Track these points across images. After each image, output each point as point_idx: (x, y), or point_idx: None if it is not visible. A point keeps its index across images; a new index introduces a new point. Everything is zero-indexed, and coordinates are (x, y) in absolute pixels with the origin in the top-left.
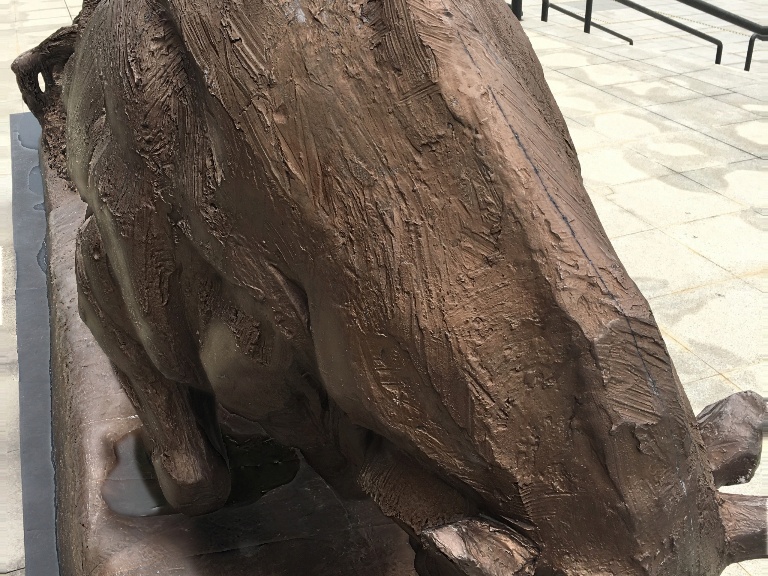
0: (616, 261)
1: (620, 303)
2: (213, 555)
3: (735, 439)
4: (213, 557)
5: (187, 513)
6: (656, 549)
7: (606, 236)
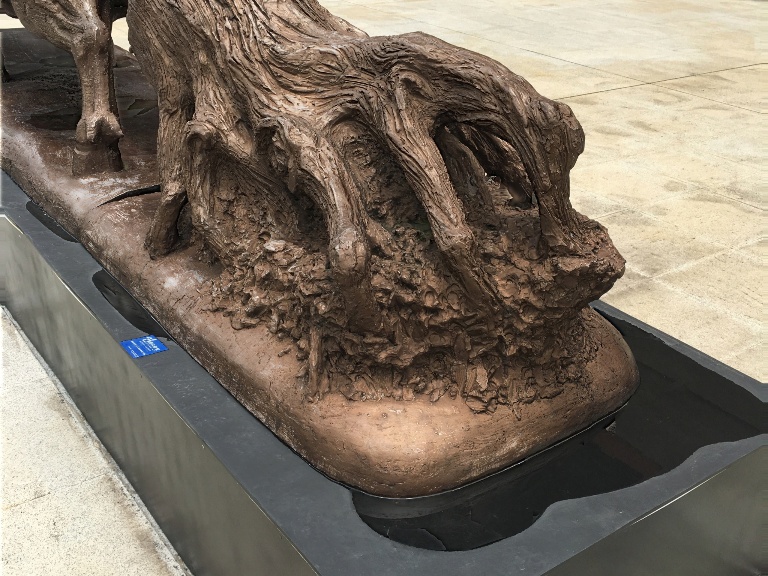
0: None
1: None
2: None
3: None
4: None
5: None
6: None
7: None
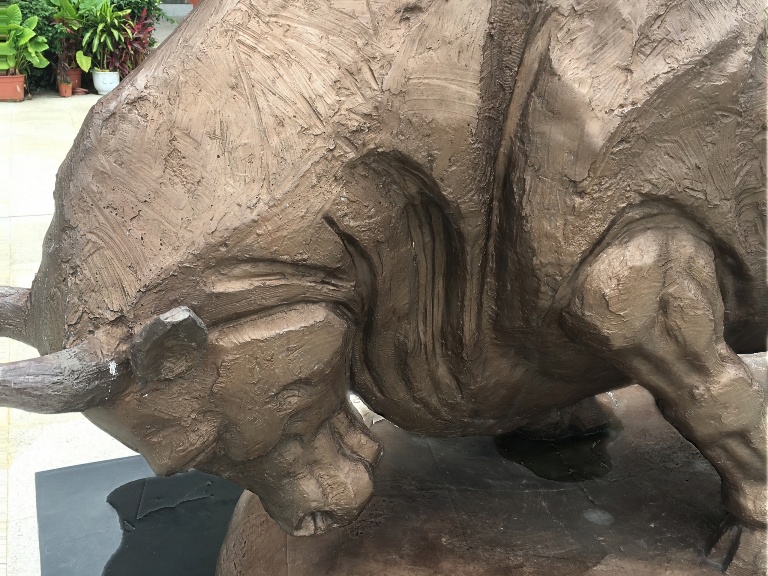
0: (136, 81)
1: (103, 97)
2: None
3: None
4: None
5: None
6: None
7: (176, 79)
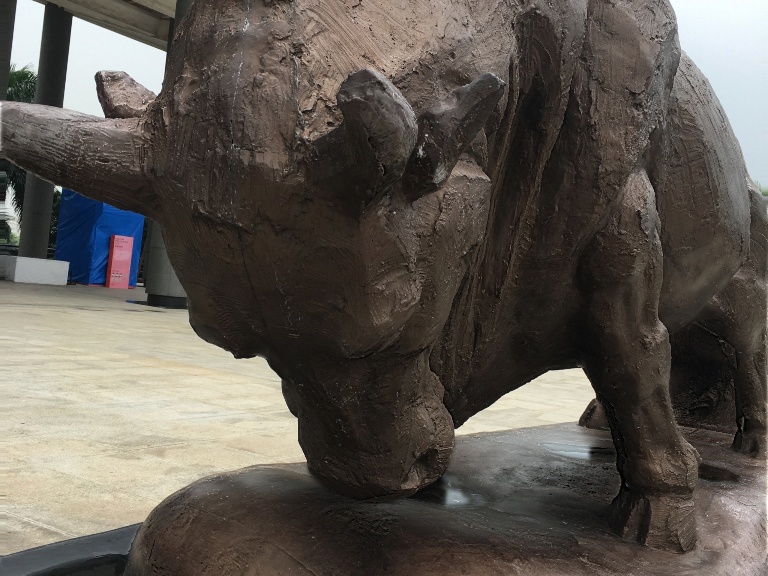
0: None
1: None
2: None
3: (431, 104)
4: None
5: (288, 402)
6: (196, 77)
7: None
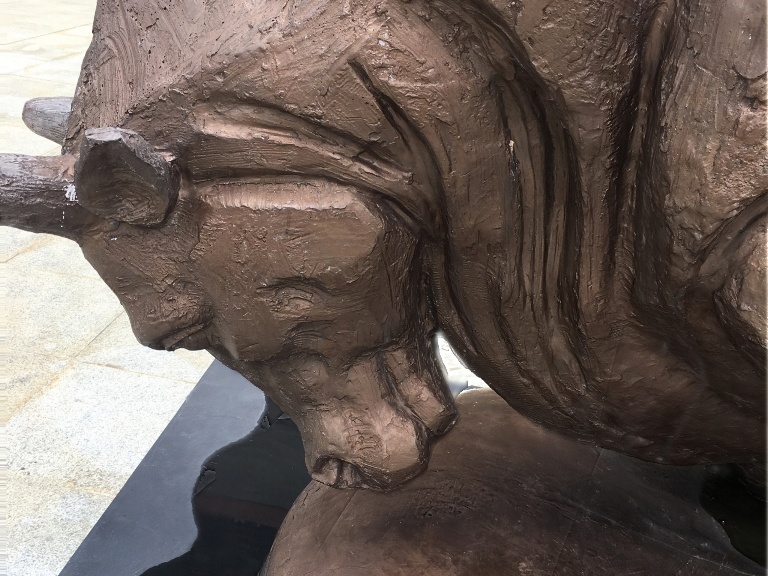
0: None
1: None
2: None
3: None
4: None
5: None
6: None
7: None
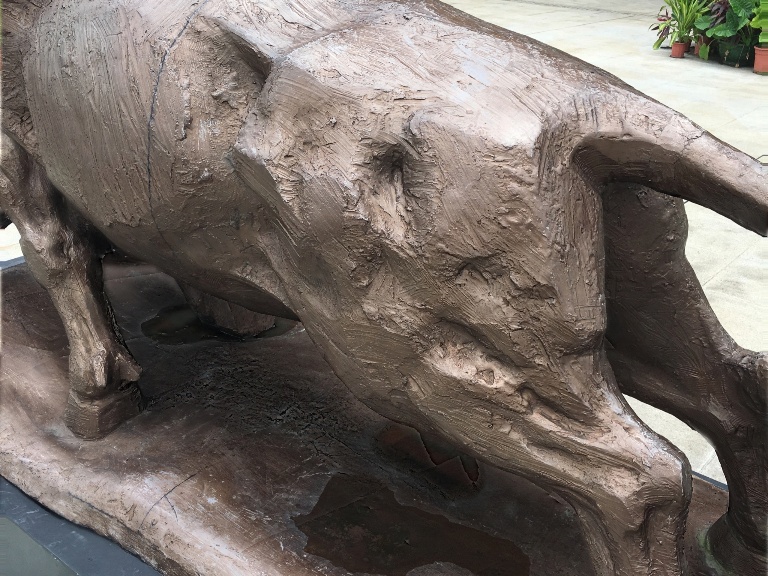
0: None
1: None
2: (156, 271)
3: None
4: (155, 270)
5: None
6: None
7: None
